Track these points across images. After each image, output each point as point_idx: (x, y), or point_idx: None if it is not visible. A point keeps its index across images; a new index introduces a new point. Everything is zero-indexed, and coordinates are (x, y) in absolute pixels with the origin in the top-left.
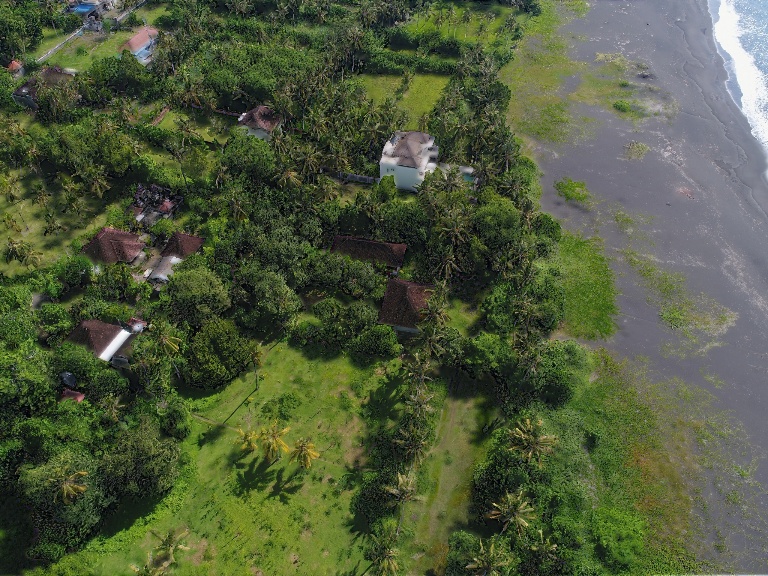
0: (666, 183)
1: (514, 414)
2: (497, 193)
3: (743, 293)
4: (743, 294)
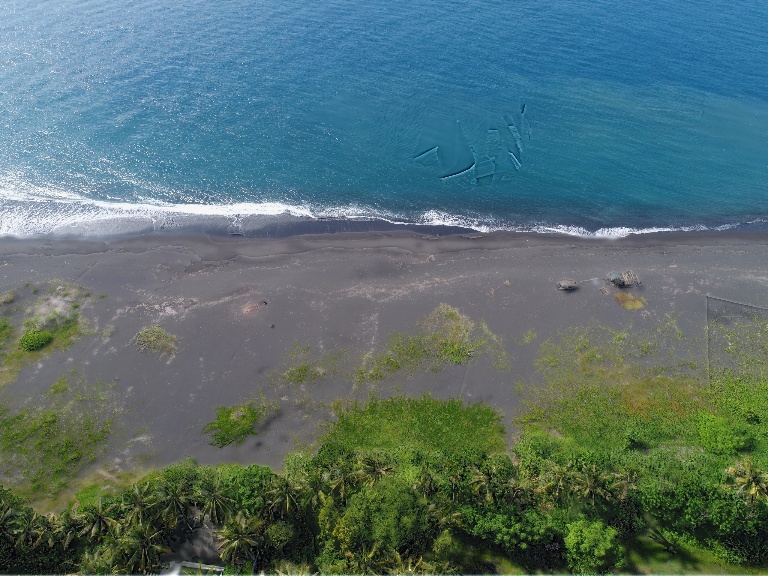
0: (233, 321)
1: (640, 517)
2: (284, 520)
3: (412, 294)
4: (413, 294)
